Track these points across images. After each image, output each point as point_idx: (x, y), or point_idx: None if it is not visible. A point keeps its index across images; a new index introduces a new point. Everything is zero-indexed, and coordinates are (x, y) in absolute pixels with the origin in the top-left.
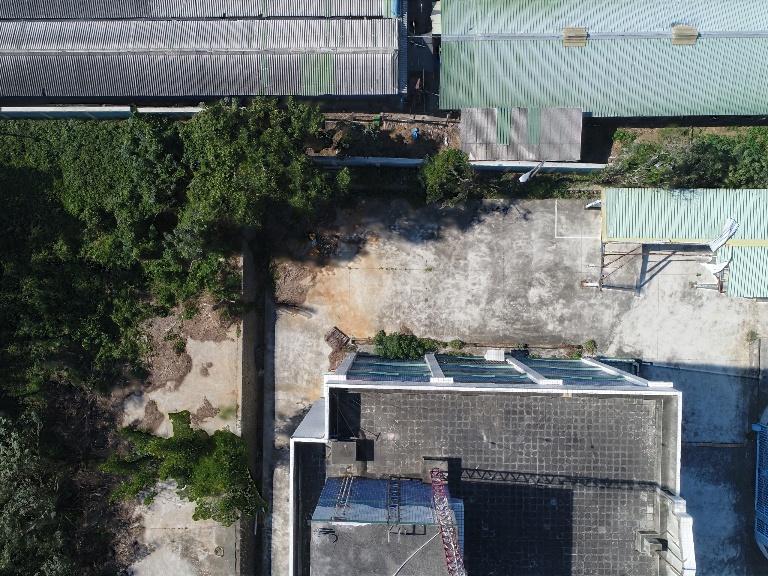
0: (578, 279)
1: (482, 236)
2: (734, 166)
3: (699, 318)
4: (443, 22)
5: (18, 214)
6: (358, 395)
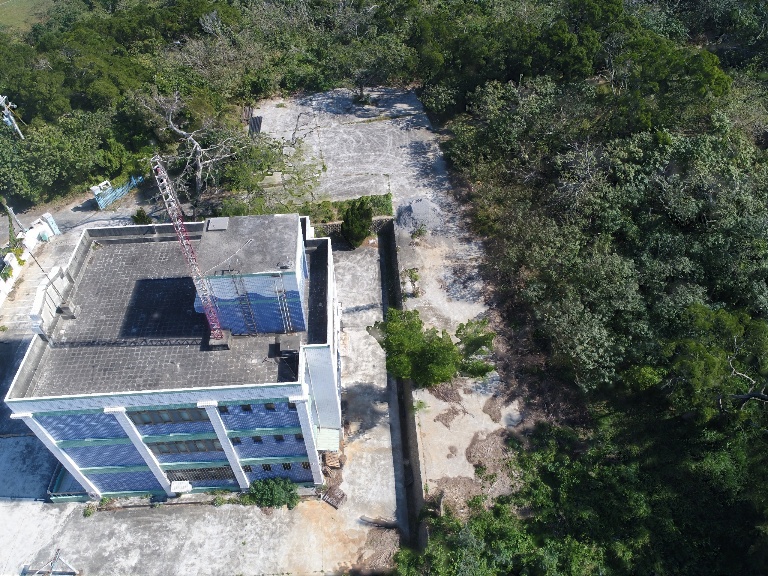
0: None
1: None
2: None
3: None
4: None
5: None
6: None
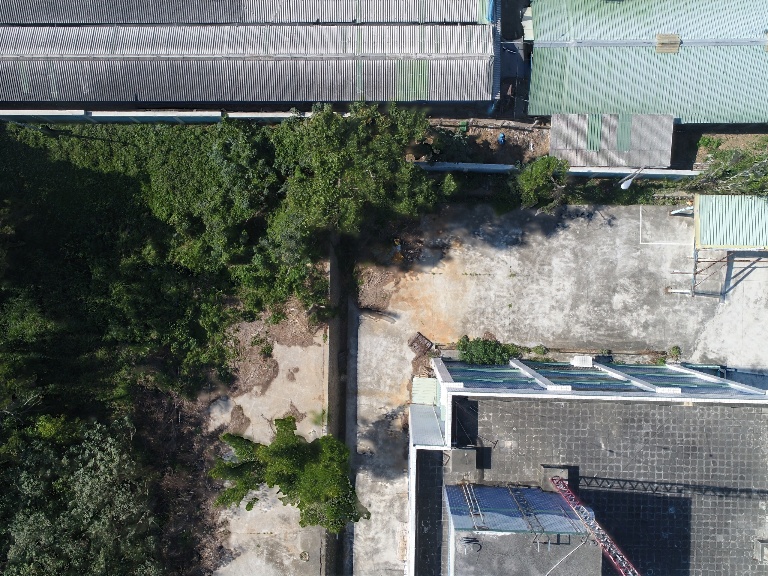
0: (662, 285)
1: (566, 242)
2: None
3: None
4: (535, 28)
5: (106, 218)
6: (476, 403)
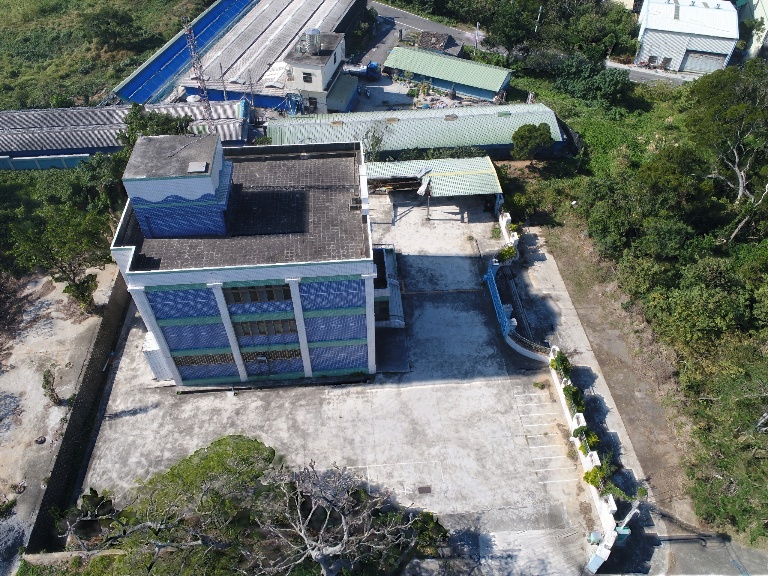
0: None
1: None
2: (426, 154)
3: (435, 233)
4: None
5: None
6: None
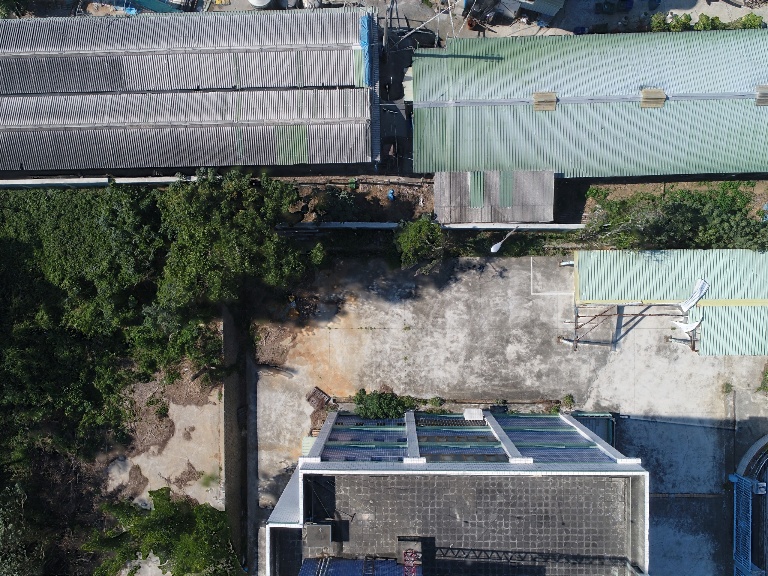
0: (555, 335)
1: (459, 294)
2: (704, 226)
3: (675, 371)
4: (415, 89)
5: None
6: (333, 477)
